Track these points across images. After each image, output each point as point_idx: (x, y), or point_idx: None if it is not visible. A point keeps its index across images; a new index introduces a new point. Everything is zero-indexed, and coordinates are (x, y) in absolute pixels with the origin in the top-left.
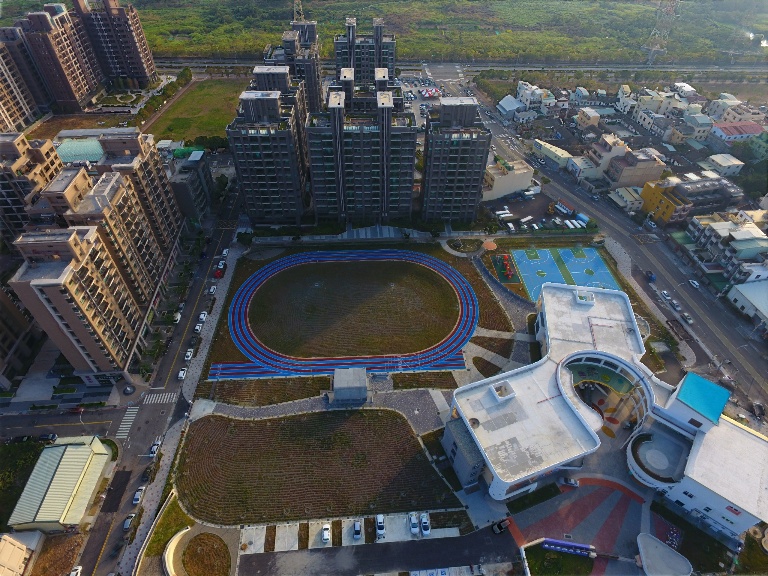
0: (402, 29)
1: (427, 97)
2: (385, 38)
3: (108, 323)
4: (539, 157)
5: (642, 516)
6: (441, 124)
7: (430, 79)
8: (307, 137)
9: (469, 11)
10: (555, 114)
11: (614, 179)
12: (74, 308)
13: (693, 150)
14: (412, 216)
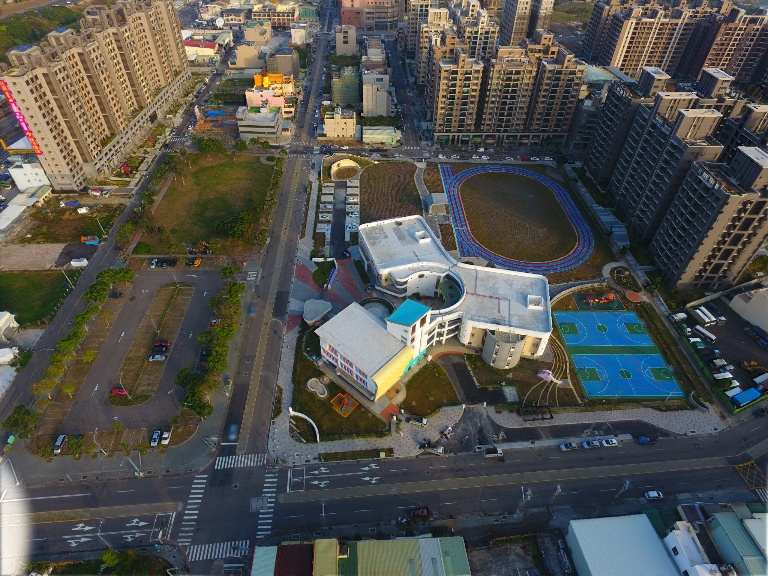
0: None
1: None
2: None
3: (447, 107)
4: None
5: None
6: (728, 170)
7: None
8: (638, 112)
9: None
10: None
11: None
12: (439, 83)
13: None
14: None
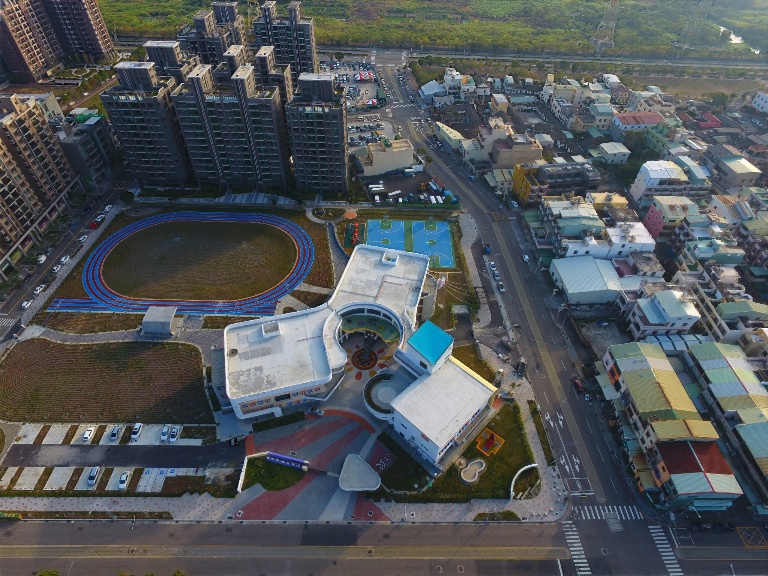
0: (370, 16)
1: (359, 80)
2: (304, 21)
3: None
4: (439, 139)
5: (366, 443)
6: (303, 98)
7: (371, 64)
8: (174, 105)
9: (444, 0)
10: (473, 100)
11: (494, 161)
12: None
13: (588, 138)
14: (290, 185)
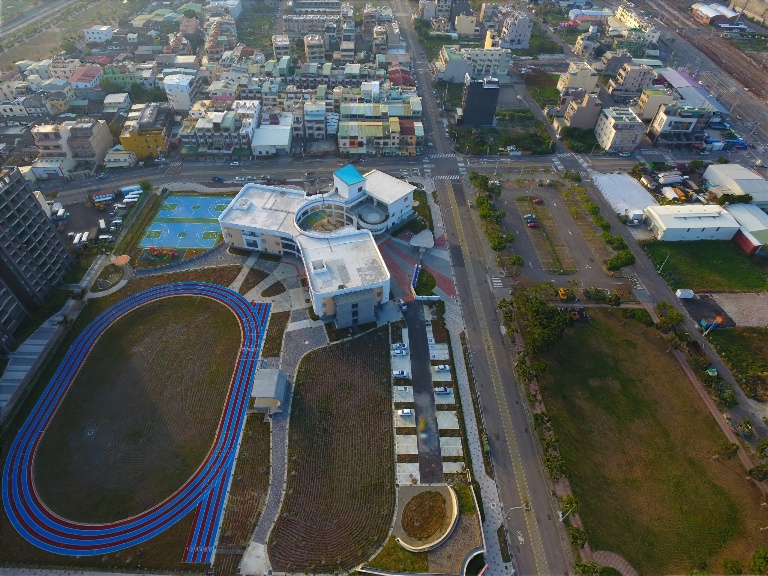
0: None
1: None
2: None
3: None
4: None
5: (398, 242)
6: None
7: None
8: None
9: None
10: None
11: (91, 155)
12: None
13: None
14: None
